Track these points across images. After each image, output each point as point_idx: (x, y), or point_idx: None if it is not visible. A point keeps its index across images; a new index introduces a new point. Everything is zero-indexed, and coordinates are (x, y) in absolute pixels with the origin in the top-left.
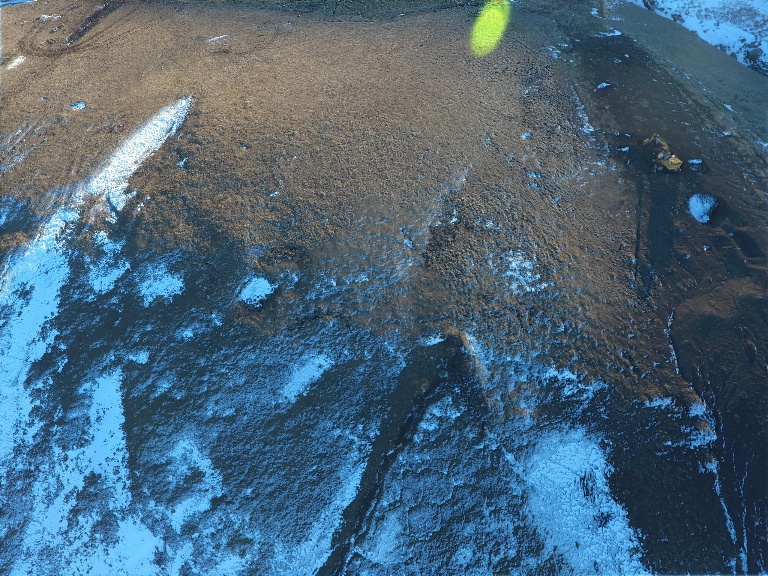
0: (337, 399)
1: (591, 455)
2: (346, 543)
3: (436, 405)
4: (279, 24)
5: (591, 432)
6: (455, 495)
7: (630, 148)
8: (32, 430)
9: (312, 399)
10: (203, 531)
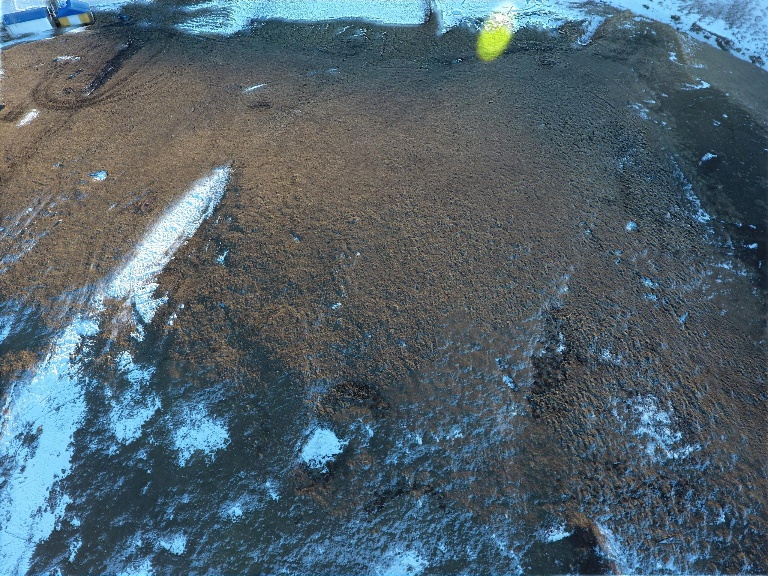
0: None
1: None
2: None
3: None
4: (323, 70)
5: None
6: None
7: (759, 245)
8: None
9: None
10: None
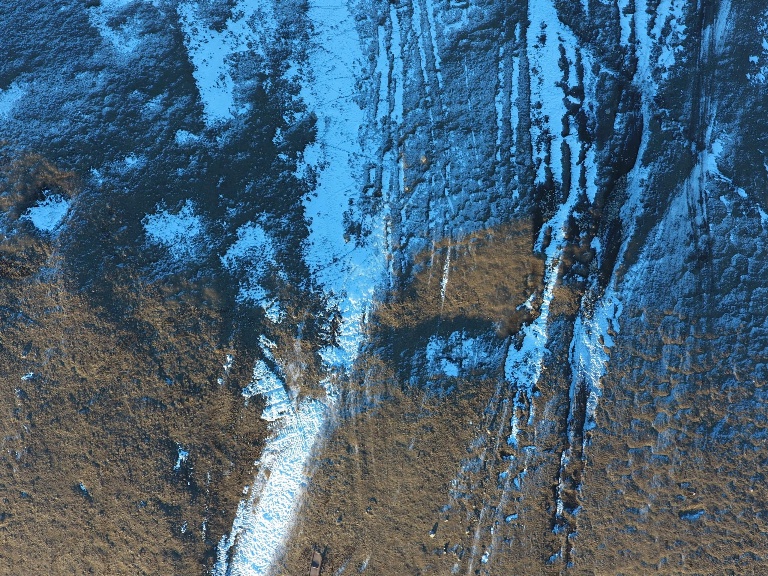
0: None
1: None
2: None
3: None
4: None
5: None
6: None
7: None
8: (292, 72)
9: None
10: None
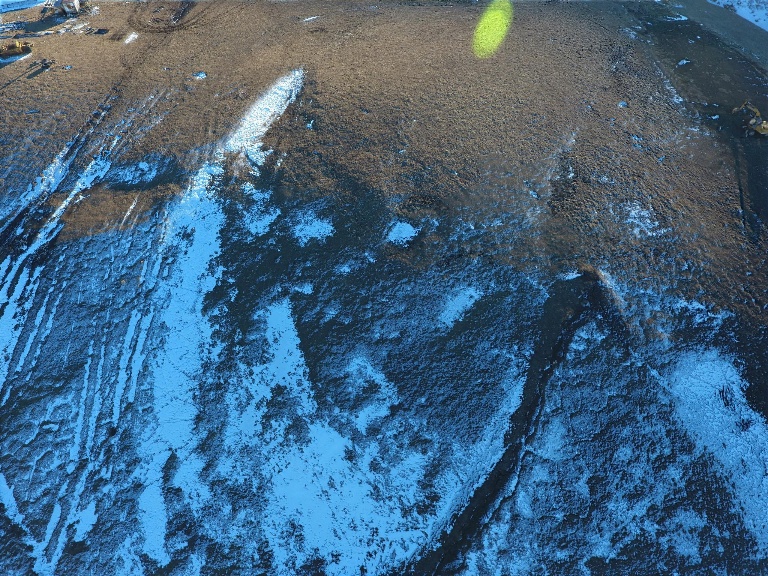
0: (491, 324)
1: (727, 372)
2: (518, 442)
3: (583, 329)
4: (365, 7)
5: (724, 353)
6: (610, 404)
7: (720, 116)
8: (216, 350)
9: (468, 324)
10: (386, 433)
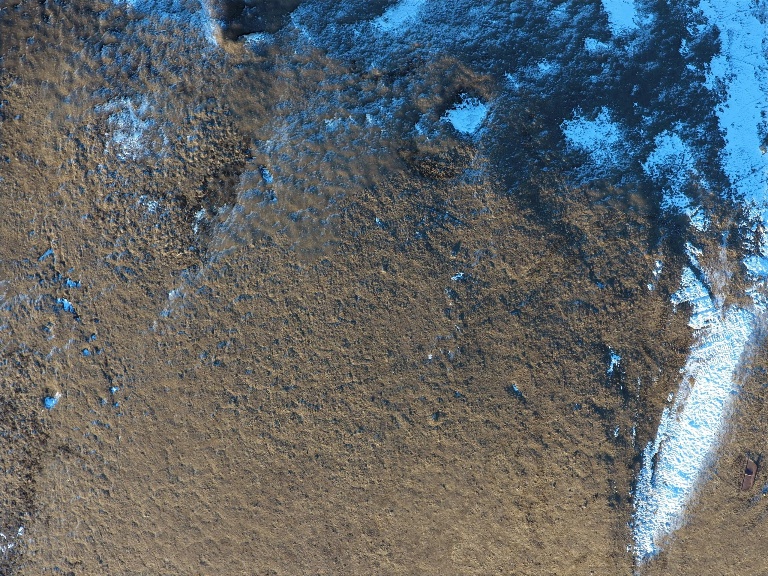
0: None
1: None
2: None
3: None
4: None
5: None
6: None
7: None
8: None
9: None
10: None
